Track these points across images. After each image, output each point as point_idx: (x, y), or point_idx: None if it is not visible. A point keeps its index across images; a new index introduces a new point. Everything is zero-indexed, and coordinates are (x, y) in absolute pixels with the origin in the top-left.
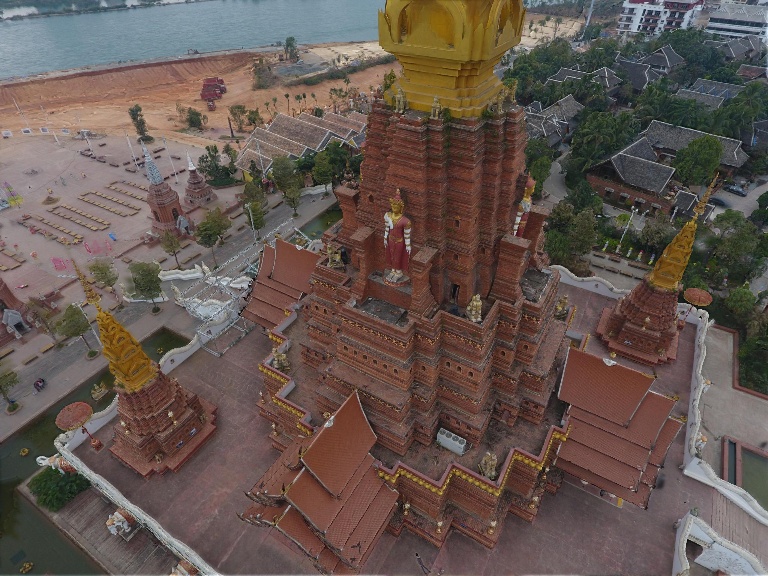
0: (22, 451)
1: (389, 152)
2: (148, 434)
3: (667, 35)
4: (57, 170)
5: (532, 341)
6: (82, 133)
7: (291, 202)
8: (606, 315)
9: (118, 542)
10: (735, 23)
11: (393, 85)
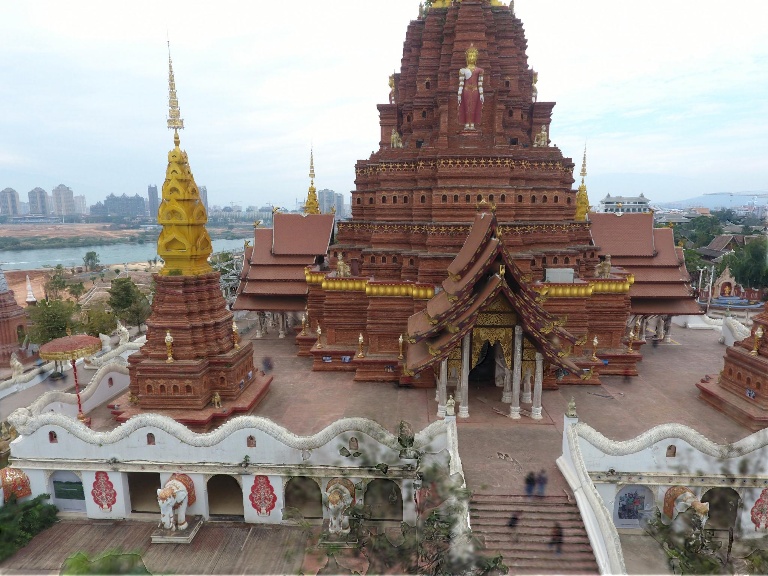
0: None
1: (457, 22)
2: (205, 357)
3: None
4: None
5: (573, 190)
6: None
7: None
8: None
9: (170, 550)
10: None
11: (434, 3)
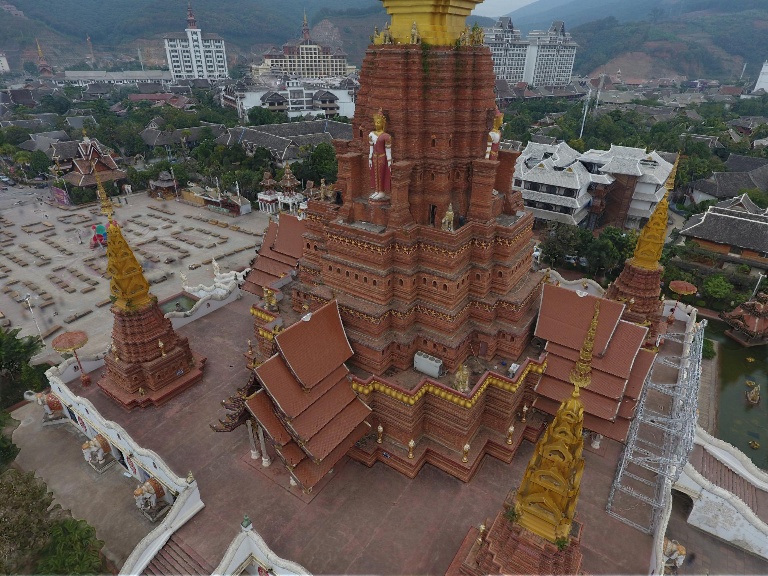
0: (752, 358)
1: None
2: None
3: None
4: None
5: None
6: None
7: None
8: (167, 389)
9: None
10: None
11: None
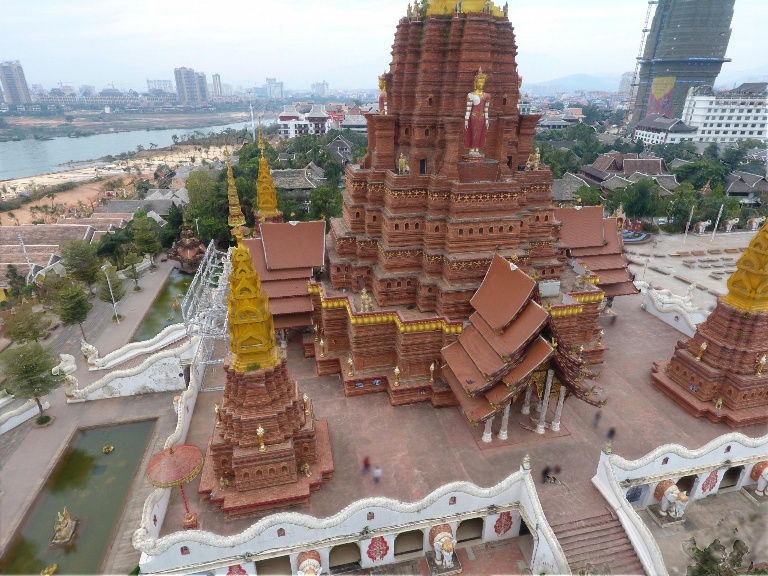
0: None
1: (465, 41)
2: None
3: (332, 131)
4: None
5: None
6: None
7: (131, 272)
8: None
9: None
10: (359, 127)
11: (432, 4)
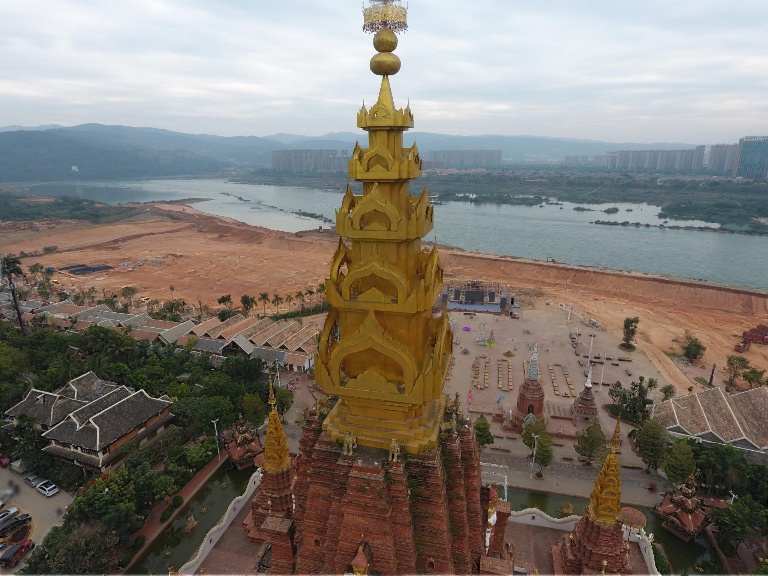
0: None
1: None
2: None
3: None
4: (541, 338)
5: None
6: (590, 321)
7: None
8: None
9: None
10: None
11: None
